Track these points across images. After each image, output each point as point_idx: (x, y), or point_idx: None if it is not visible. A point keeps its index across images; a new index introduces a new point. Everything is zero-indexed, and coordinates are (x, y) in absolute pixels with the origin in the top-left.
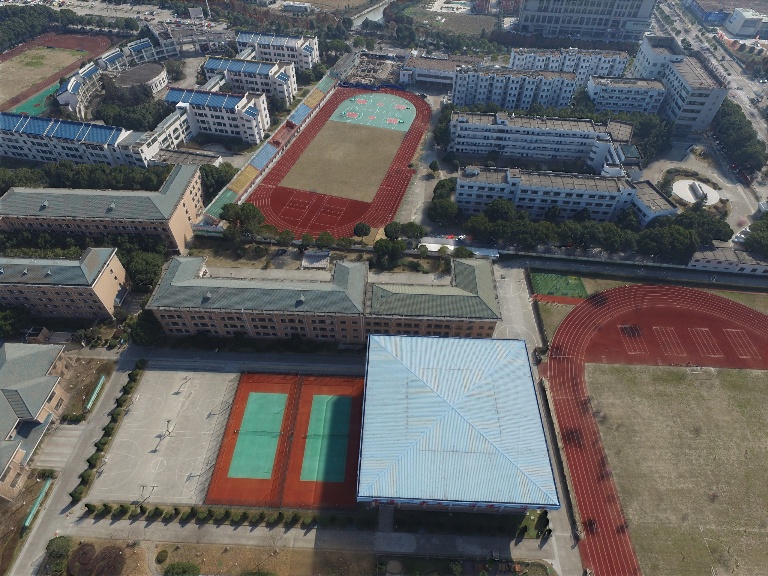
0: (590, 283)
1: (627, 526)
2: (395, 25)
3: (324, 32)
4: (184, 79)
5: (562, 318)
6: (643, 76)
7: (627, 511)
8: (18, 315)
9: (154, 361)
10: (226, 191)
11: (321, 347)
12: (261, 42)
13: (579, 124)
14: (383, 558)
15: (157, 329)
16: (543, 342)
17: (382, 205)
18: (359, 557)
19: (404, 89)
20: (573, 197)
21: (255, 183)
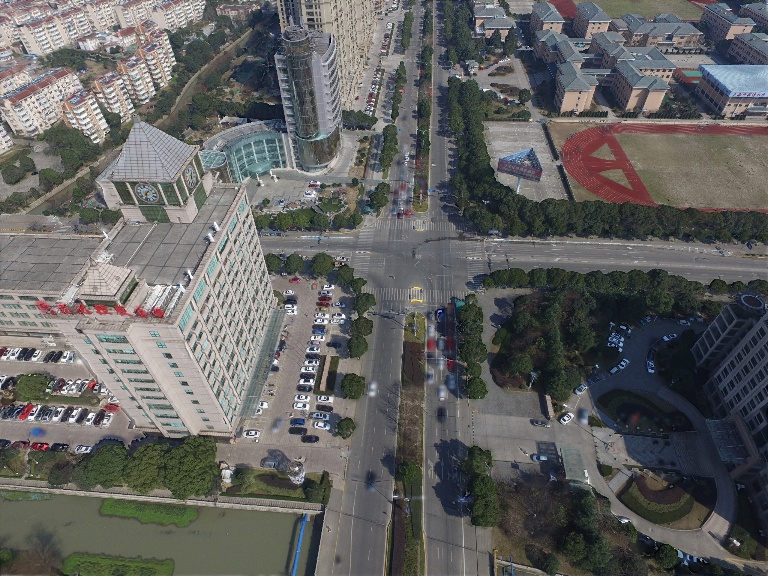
0: None
1: None
2: None
3: None
4: None
5: None
6: None
7: None
8: (706, 27)
9: None
10: None
11: None
12: None
13: None
14: None
15: (726, 47)
16: None
17: None
18: None
19: None
20: None
21: None
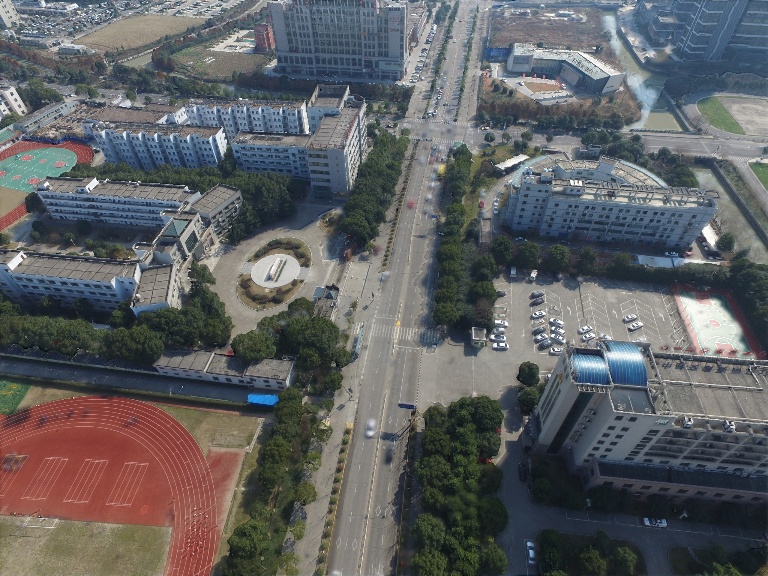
0: (34, 394)
1: None
2: None
3: None
4: None
5: None
6: None
7: None
8: None
9: None
10: None
11: None
12: None
13: (170, 191)
14: None
15: None
16: None
17: None
18: None
19: (85, 142)
20: (70, 286)
21: None
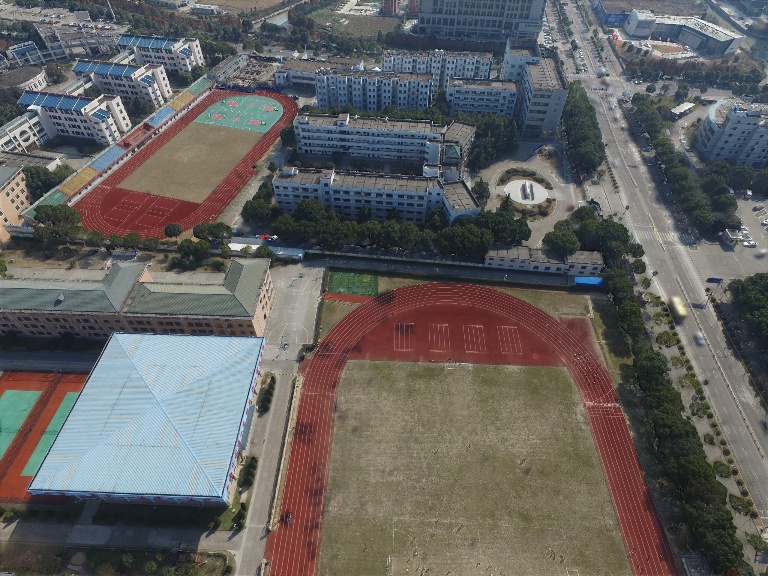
0: (385, 282)
1: (323, 518)
2: (292, 27)
3: (223, 34)
4: (65, 82)
5: (343, 316)
6: (505, 77)
7: (329, 503)
8: None
9: None
10: (54, 193)
11: (93, 345)
12: (140, 45)
13: (418, 125)
14: (71, 550)
15: None
16: (314, 339)
17: (211, 206)
18: (48, 549)
19: (279, 91)
20: (384, 197)
21: (93, 185)
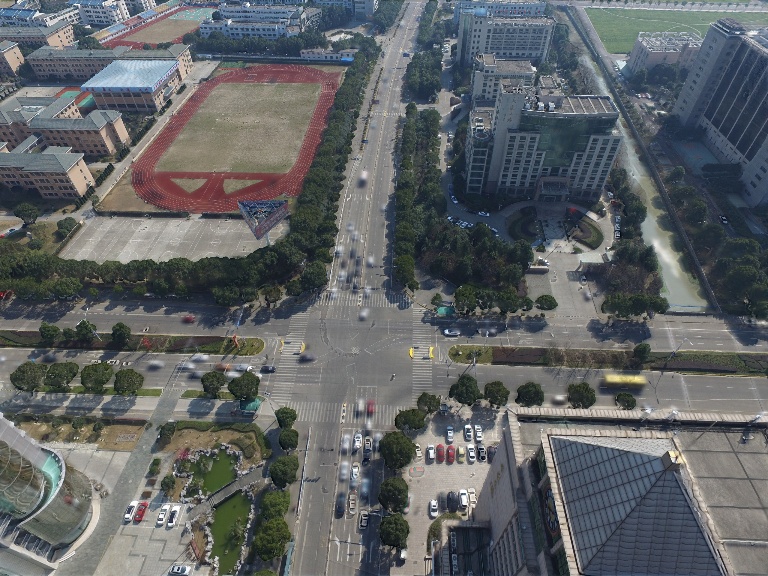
0: (249, 64)
1: None
2: None
3: None
4: None
5: (224, 73)
6: None
7: (199, 110)
8: None
9: (29, 85)
10: None
11: None
12: None
13: (287, 7)
14: None
15: (31, 72)
16: None
17: None
18: None
19: None
20: (255, 31)
21: (108, 39)
